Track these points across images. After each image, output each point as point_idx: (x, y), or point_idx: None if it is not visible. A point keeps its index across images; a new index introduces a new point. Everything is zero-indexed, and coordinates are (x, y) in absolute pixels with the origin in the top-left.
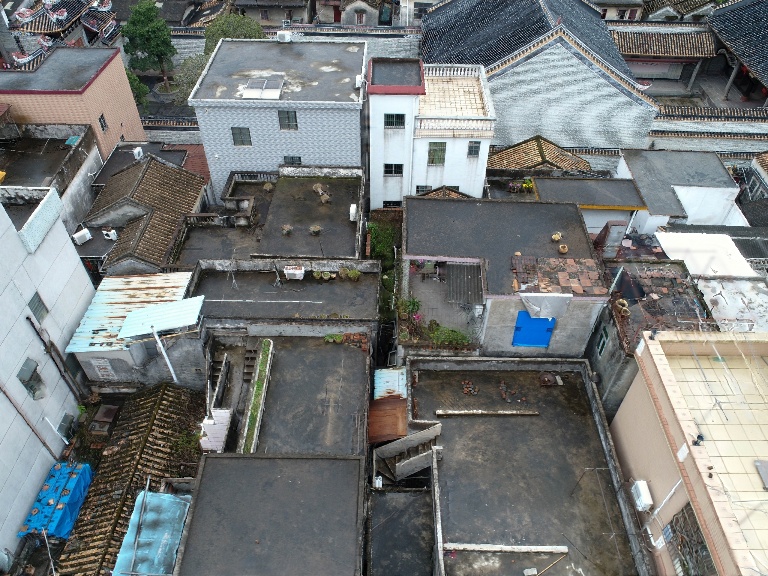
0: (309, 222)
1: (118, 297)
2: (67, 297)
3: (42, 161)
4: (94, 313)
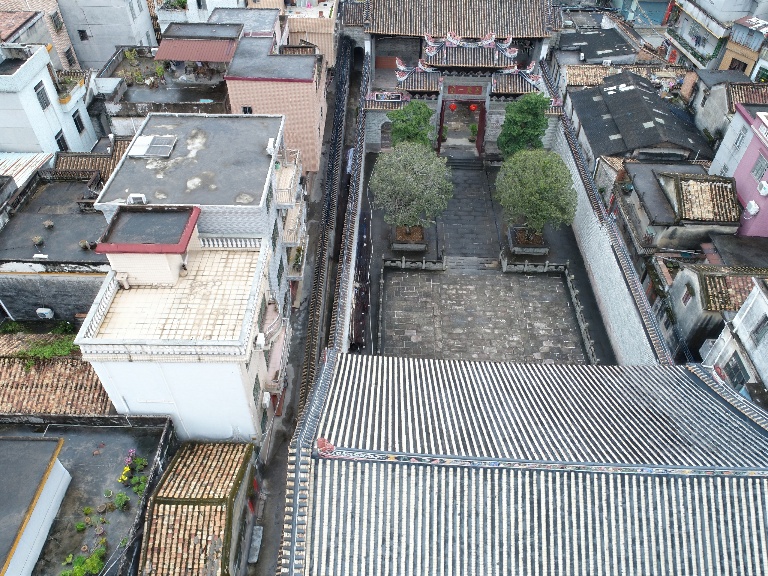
0: (58, 239)
1: (24, 160)
2: (7, 133)
3: (199, 100)
4: (15, 155)
